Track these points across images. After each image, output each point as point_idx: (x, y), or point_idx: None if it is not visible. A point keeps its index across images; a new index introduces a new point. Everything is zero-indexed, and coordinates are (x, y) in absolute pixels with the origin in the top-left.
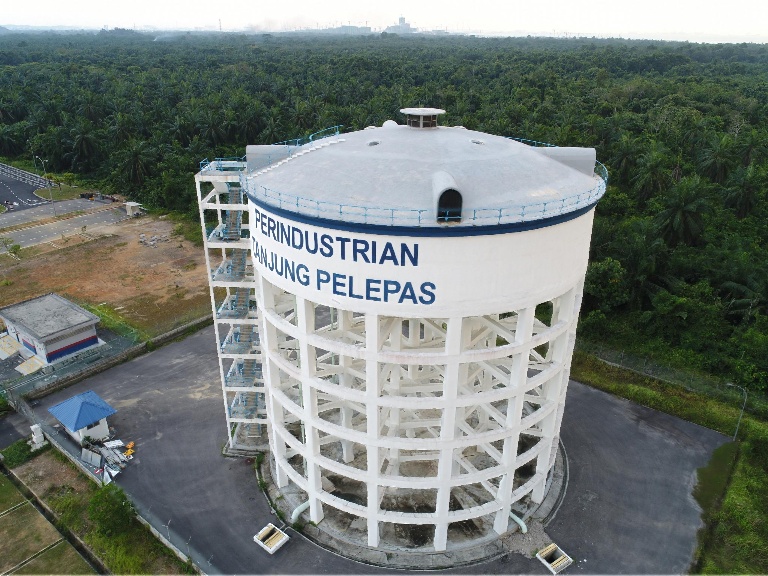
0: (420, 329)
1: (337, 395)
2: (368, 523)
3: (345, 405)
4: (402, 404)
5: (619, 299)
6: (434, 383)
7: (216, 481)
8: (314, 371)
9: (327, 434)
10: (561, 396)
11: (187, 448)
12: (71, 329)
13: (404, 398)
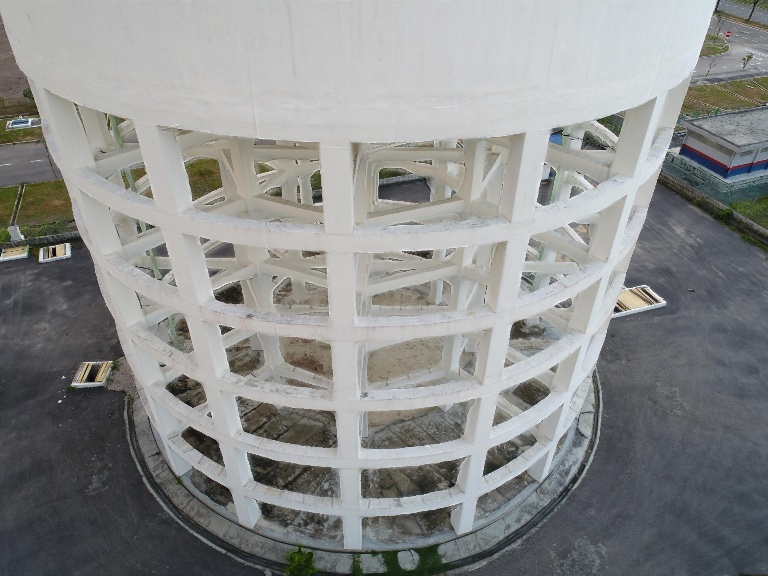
0: None
1: None
2: None
3: None
4: None
5: None
6: None
7: None
8: None
9: (429, 284)
10: None
11: None
12: (709, 135)
13: None
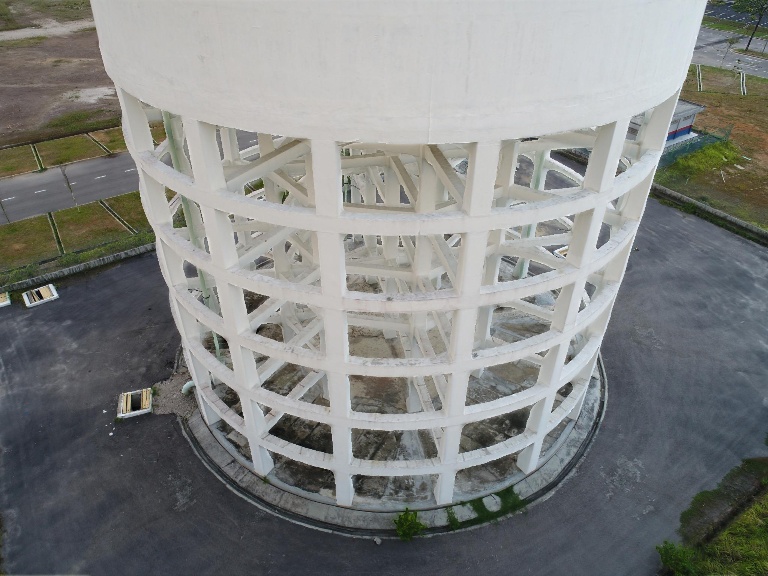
0: (762, 452)
1: None
2: None
3: None
4: None
5: None
6: (288, 201)
7: None
8: None
9: None
10: None
11: None
12: None
13: None
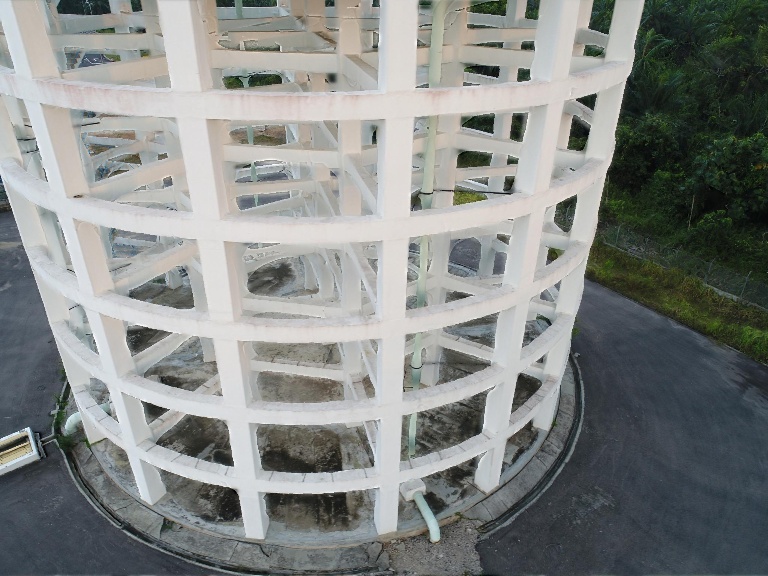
0: None
1: (22, 193)
2: (129, 460)
3: (187, 262)
4: (109, 217)
5: (763, 199)
6: None
7: (18, 354)
8: (11, 148)
9: None
10: (540, 283)
11: (22, 306)
12: None
13: (116, 205)
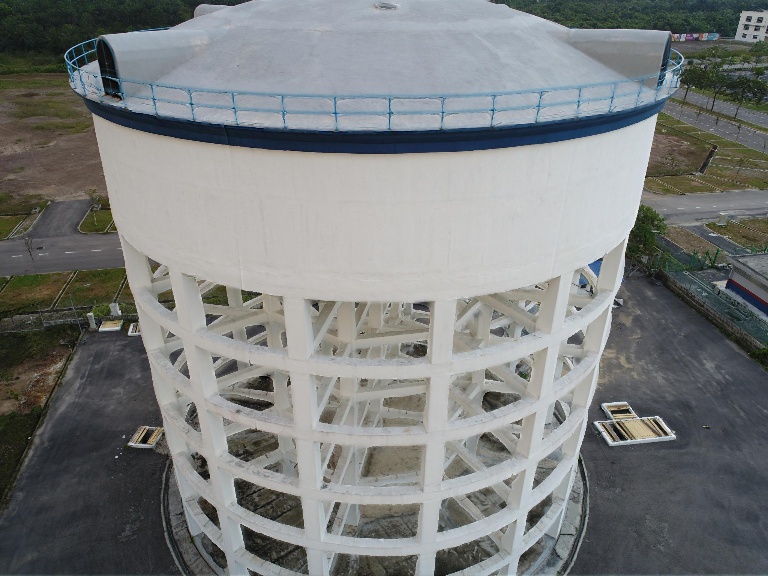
0: None
1: None
2: None
3: None
4: None
5: None
6: None
7: None
8: None
9: None
10: None
11: None
12: (752, 273)
13: None
